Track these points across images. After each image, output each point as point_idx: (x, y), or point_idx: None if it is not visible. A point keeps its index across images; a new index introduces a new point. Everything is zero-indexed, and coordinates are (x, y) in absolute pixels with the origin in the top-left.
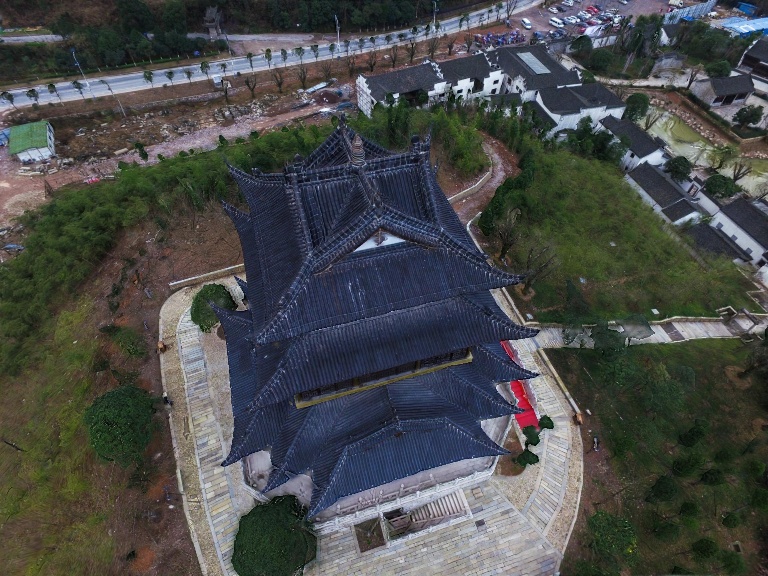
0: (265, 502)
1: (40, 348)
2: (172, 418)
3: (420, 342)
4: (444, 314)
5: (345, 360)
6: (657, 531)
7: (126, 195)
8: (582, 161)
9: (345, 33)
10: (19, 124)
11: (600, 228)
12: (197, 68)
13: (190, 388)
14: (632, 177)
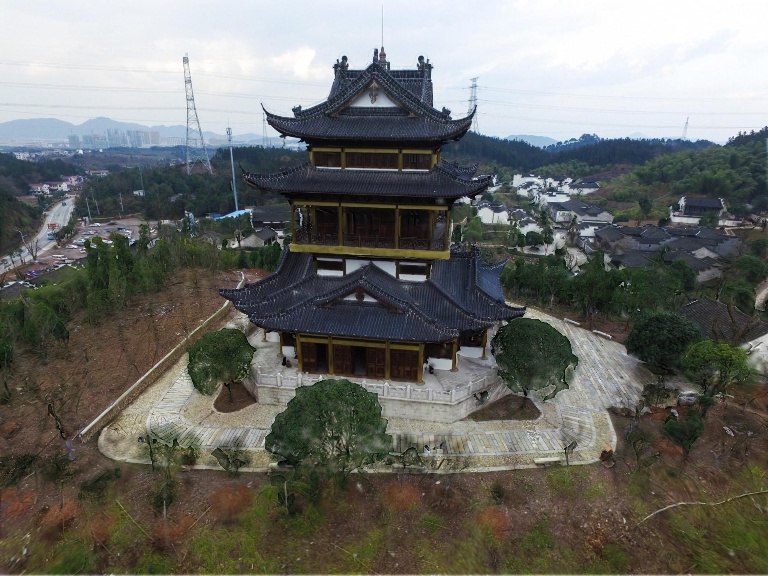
0: None
1: None
2: None
3: None
4: None
5: None
6: (546, 300)
7: None
8: None
9: None
10: None
11: None
12: None
13: None
14: None
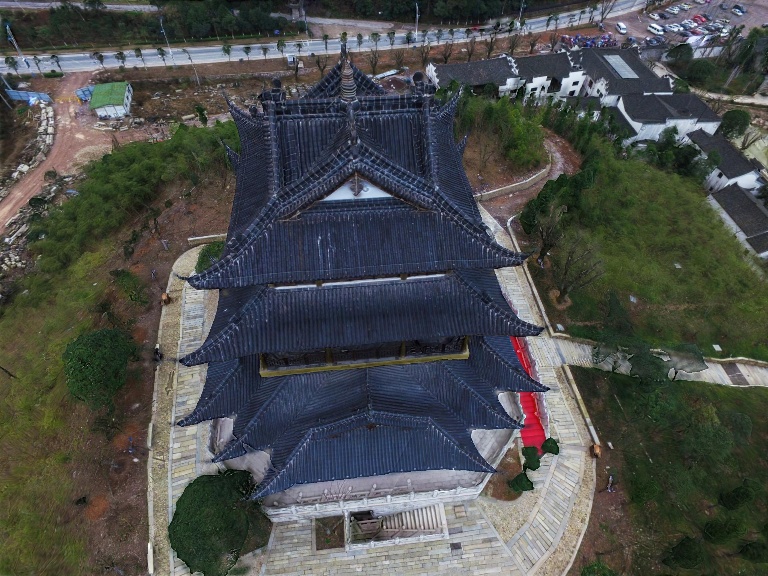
0: None
1: (62, 285)
2: (159, 371)
3: (399, 321)
4: (434, 294)
5: (309, 327)
6: None
7: (172, 151)
8: (658, 173)
9: (426, 24)
10: (104, 83)
11: (665, 246)
12: (275, 46)
13: (183, 344)
14: (716, 198)
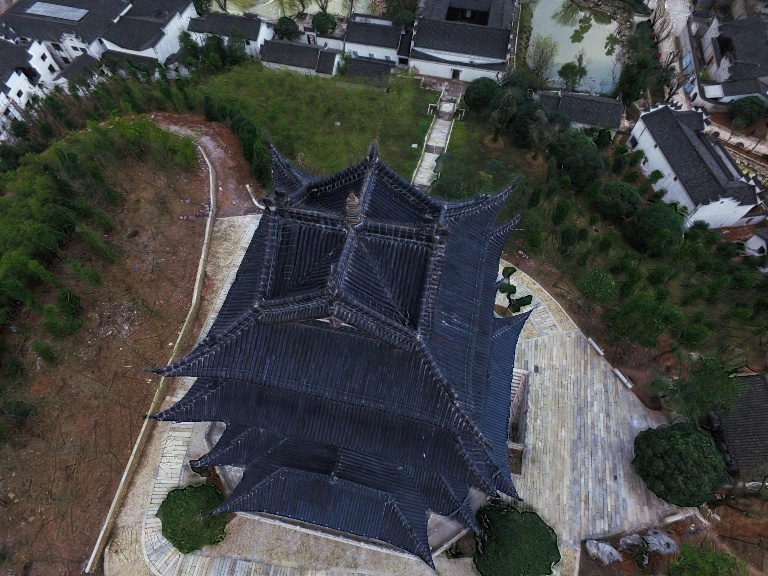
0: (452, 544)
1: None
2: None
3: None
4: None
5: None
6: (582, 263)
7: None
8: (230, 76)
9: None
10: None
11: None
12: None
13: None
14: (269, 61)
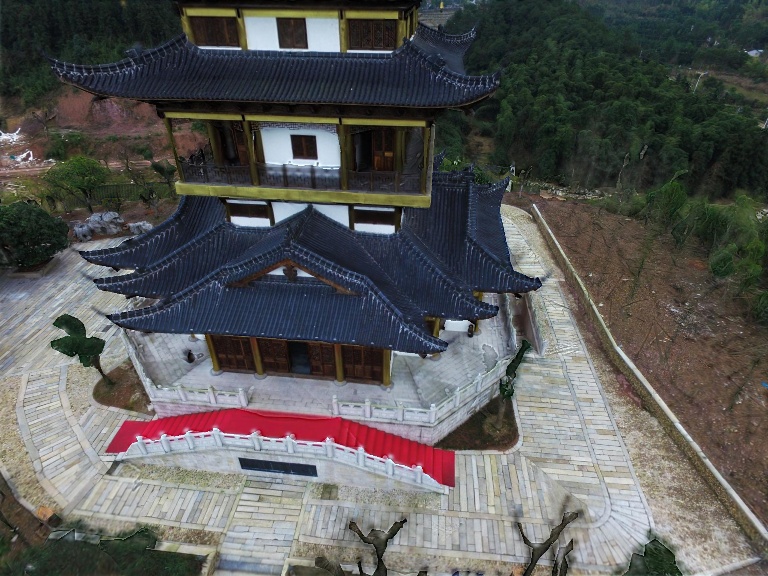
0: None
1: None
2: None
3: None
4: None
5: None
6: None
7: None
8: None
9: None
10: None
11: None
12: None
13: None
14: None
